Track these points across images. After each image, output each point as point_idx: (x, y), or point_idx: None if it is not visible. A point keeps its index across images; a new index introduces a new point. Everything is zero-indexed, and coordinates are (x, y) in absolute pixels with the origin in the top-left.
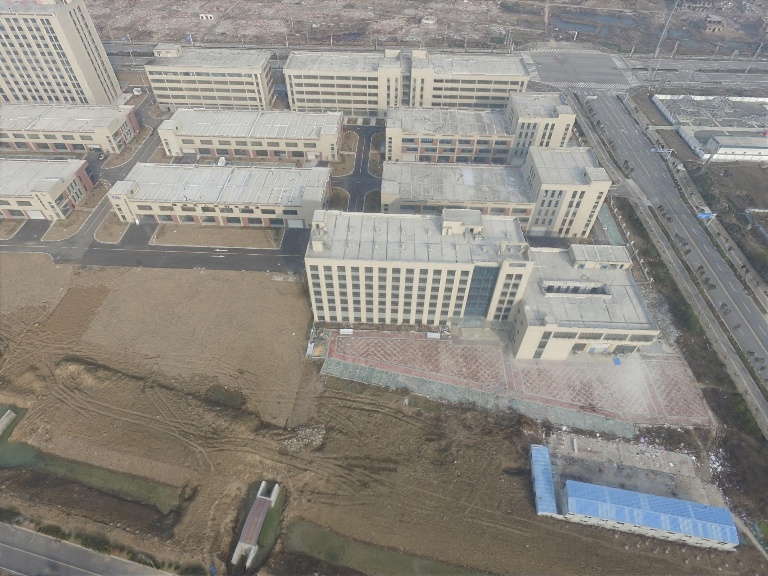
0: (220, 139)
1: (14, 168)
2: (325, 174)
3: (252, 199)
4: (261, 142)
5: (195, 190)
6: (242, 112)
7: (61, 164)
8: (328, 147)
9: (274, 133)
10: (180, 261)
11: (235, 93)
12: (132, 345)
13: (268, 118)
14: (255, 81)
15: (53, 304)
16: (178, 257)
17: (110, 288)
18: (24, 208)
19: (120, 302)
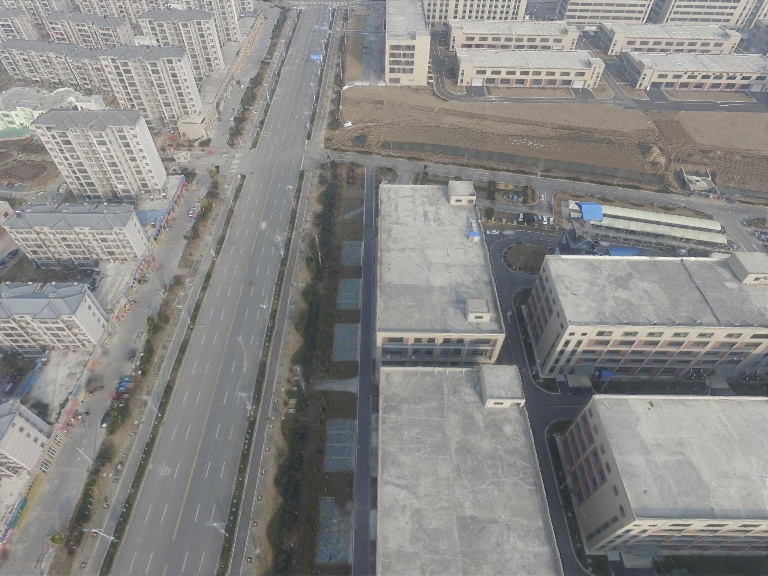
0: (656, 40)
1: (547, 55)
2: (759, 58)
3: (733, 70)
4: (684, 42)
5: (688, 66)
6: (647, 25)
7: (574, 53)
8: (730, 46)
9: (689, 37)
10: (704, 108)
11: (627, 14)
12: (733, 145)
13: (671, 28)
14: (648, 4)
15: (654, 128)
16: (700, 106)
17: (679, 121)
18: (576, 78)
19: (695, 127)
